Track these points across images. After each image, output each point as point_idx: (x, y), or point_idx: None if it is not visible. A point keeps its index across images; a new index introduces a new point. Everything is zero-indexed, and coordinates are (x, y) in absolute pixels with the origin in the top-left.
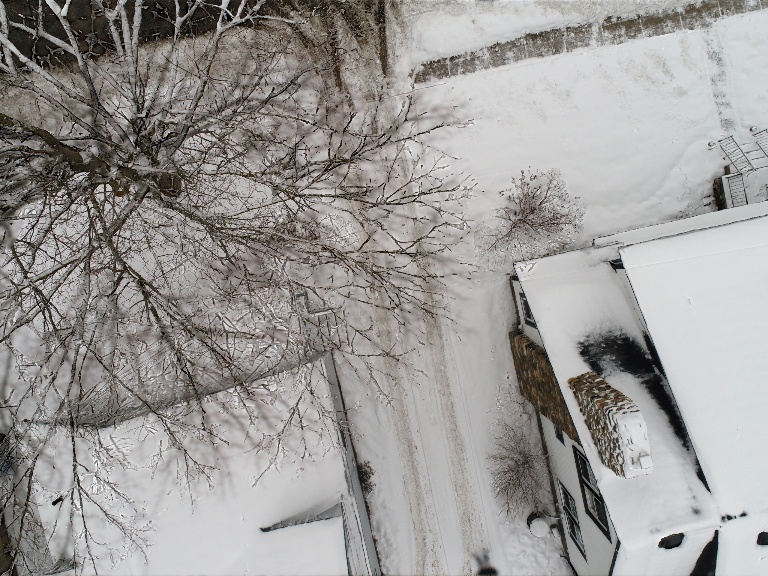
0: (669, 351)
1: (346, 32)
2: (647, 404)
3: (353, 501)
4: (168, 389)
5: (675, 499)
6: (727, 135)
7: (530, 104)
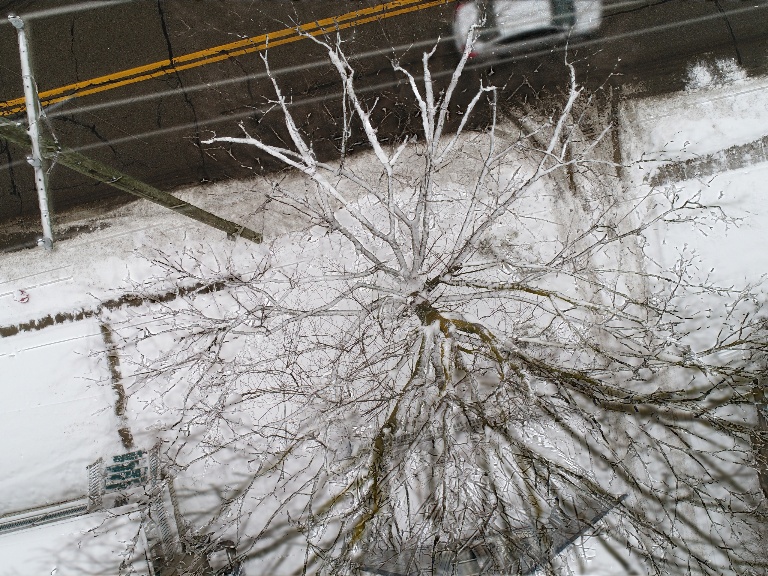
0: None
1: (579, 136)
2: None
3: None
4: None
5: None
6: None
7: None
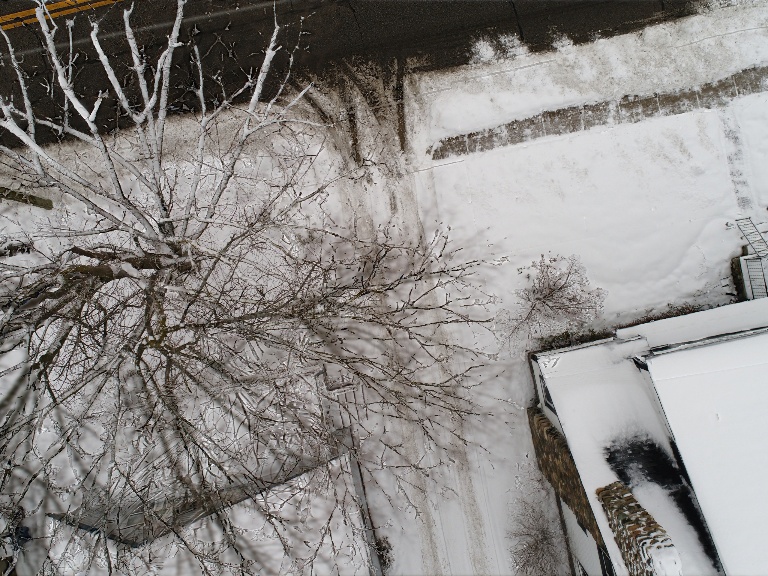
0: (698, 469)
1: (365, 108)
2: (676, 519)
3: None
4: (195, 495)
5: None
6: (744, 213)
7: (548, 182)
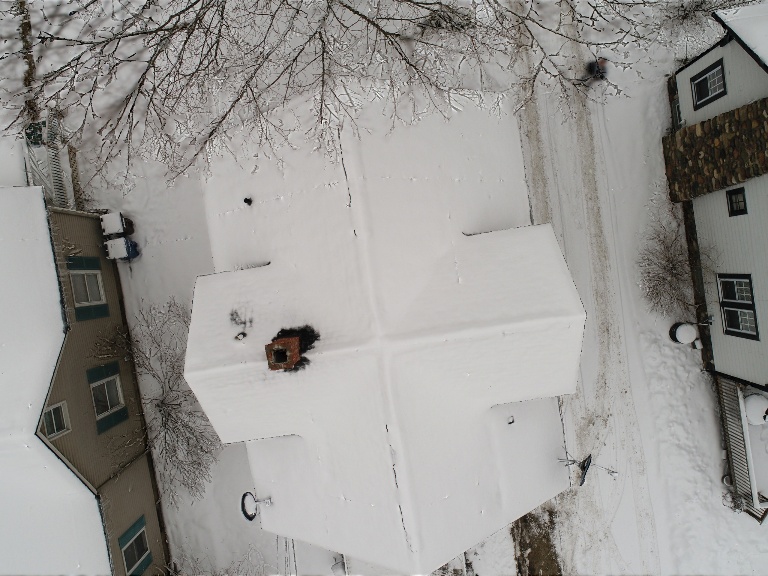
0: None
1: None
2: None
3: None
4: None
5: None
6: None
7: None
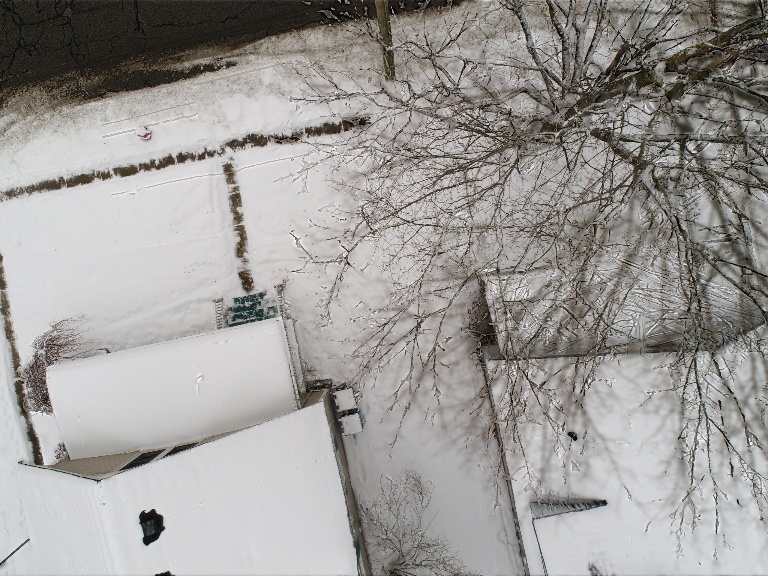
0: None
1: None
2: None
3: None
4: None
5: None
6: None
7: None
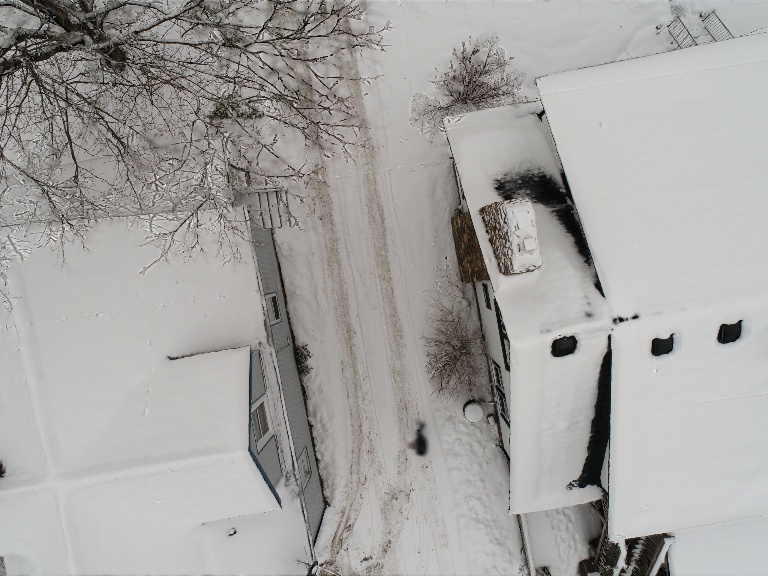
0: (576, 169)
1: None
2: (555, 228)
3: (272, 351)
4: None
5: (569, 304)
6: None
7: None
